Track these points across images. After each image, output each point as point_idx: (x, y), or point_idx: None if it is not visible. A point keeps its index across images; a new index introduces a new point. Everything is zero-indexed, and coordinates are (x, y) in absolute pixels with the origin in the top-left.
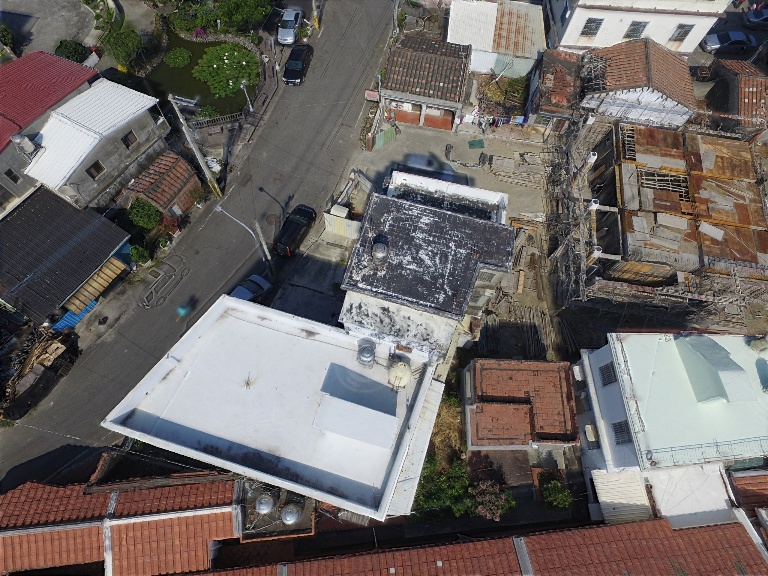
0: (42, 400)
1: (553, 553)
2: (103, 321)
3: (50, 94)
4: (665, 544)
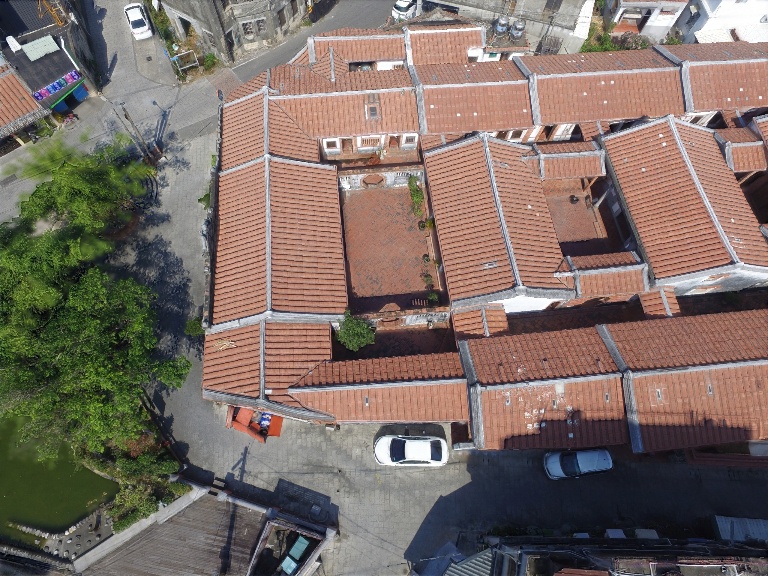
0: (326, 14)
1: (679, 48)
2: None
3: None
4: (747, 45)
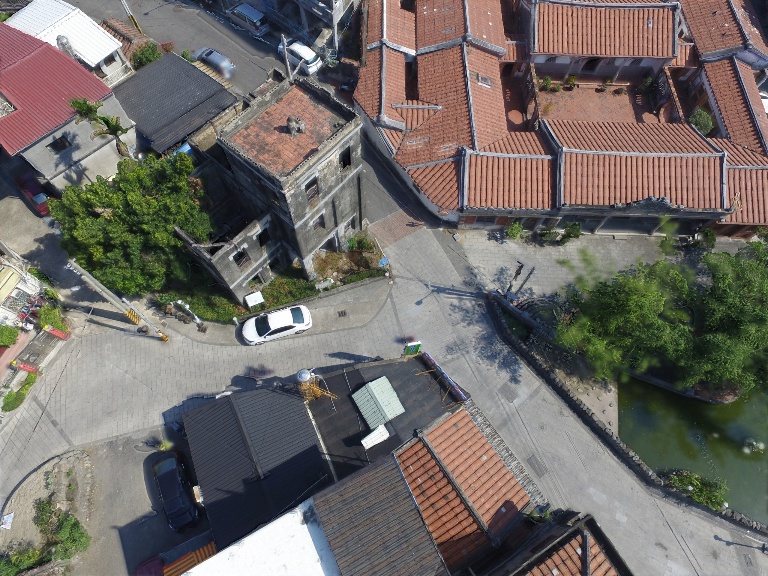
0: None
1: None
2: (237, 100)
3: (8, 39)
4: None
